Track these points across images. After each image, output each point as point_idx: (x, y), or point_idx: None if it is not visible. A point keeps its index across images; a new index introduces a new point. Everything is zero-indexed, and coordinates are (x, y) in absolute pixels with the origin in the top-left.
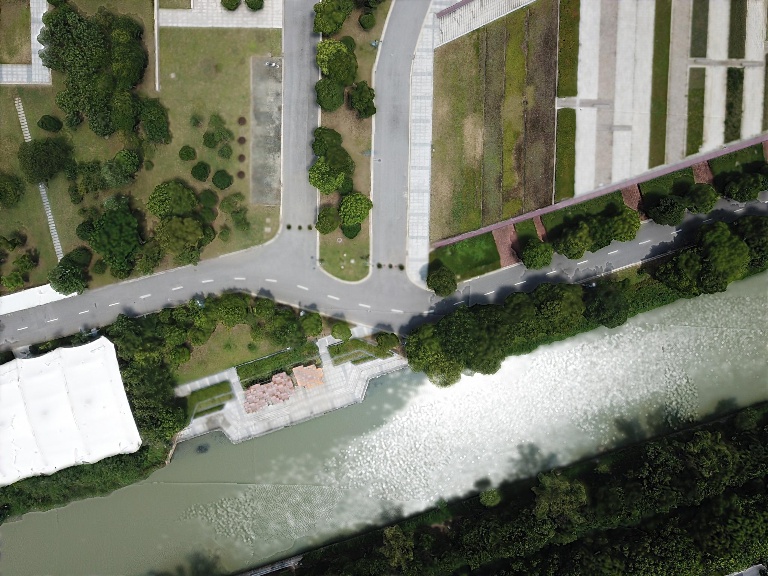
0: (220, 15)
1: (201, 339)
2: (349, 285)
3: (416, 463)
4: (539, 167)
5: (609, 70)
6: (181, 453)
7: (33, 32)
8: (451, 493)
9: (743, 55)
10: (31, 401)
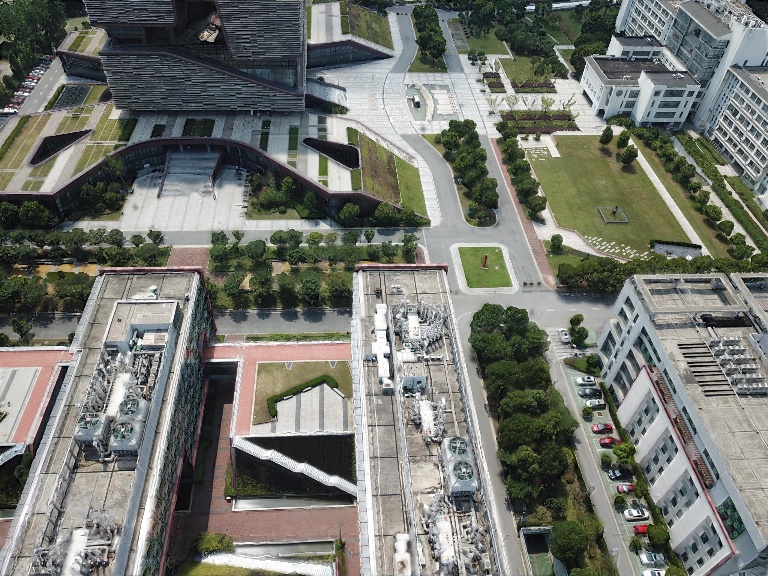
0: None
1: None
2: None
3: None
4: None
5: (328, 21)
6: None
7: (559, 54)
8: None
9: None
10: None
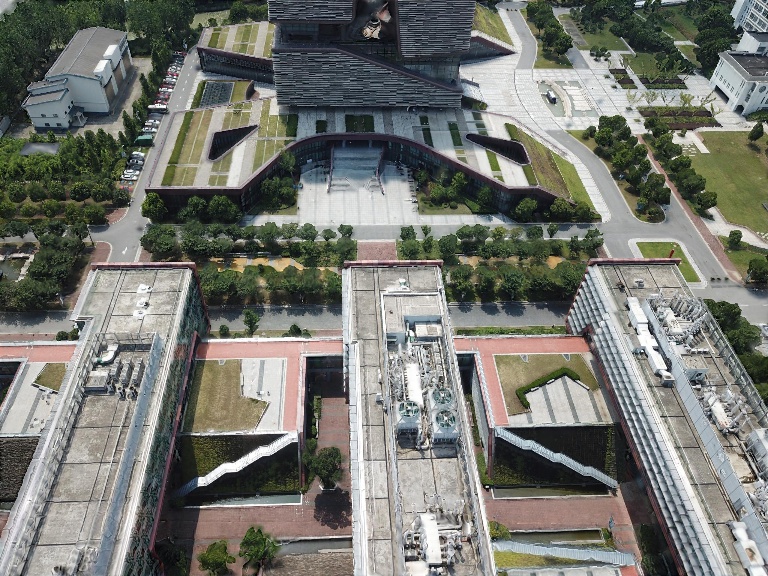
0: None
1: None
2: None
3: None
4: None
5: None
6: None
7: None
8: None
9: None
10: None
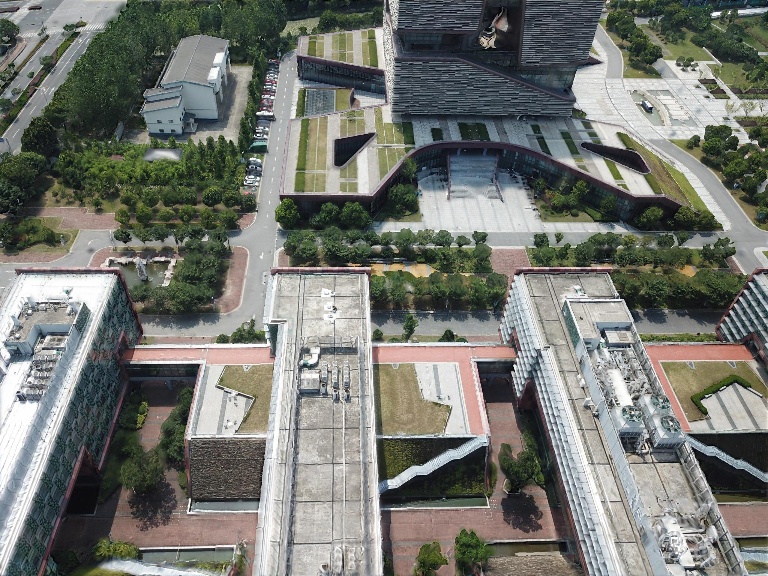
0: None
1: None
2: None
3: None
4: None
5: None
6: None
7: None
8: None
9: None
10: None
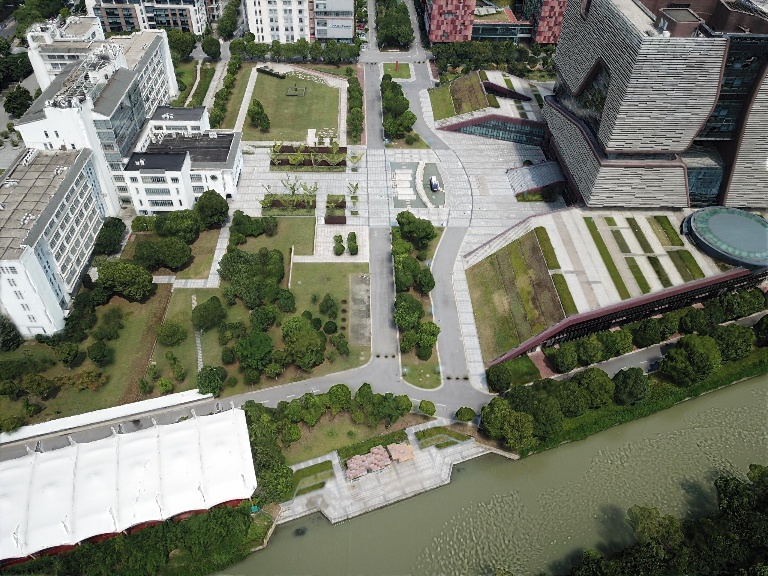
0: (331, 258)
1: (313, 415)
2: (427, 392)
3: (509, 562)
4: (550, 303)
5: (576, 259)
6: (277, 540)
7: (213, 266)
8: (551, 571)
9: (653, 252)
10: (166, 450)
